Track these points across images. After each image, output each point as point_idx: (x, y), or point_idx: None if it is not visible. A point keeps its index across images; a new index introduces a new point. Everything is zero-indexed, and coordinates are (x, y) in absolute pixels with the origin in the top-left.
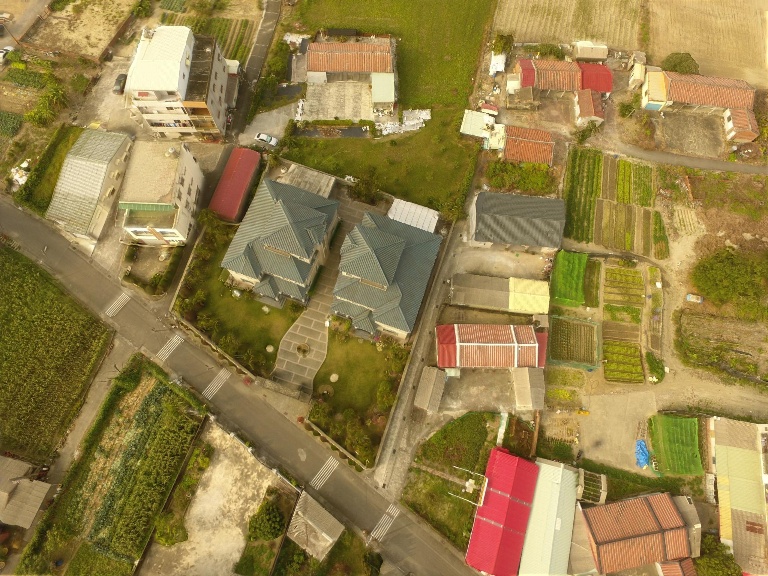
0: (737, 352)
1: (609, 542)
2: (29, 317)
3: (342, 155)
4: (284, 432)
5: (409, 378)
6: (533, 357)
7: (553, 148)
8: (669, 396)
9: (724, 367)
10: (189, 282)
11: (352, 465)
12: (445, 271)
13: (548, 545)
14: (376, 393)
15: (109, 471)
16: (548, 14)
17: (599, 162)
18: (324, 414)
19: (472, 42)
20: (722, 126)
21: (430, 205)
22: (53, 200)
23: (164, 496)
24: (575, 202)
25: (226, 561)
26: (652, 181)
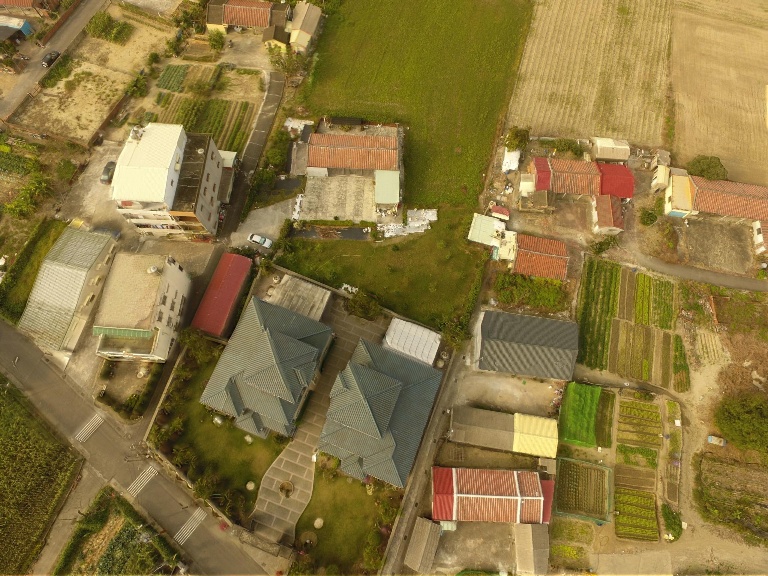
0: (762, 506)
1: None
2: None
3: (340, 260)
4: None
5: (400, 526)
6: (537, 512)
7: None
8: (686, 558)
9: (748, 525)
10: None
11: None
12: (445, 399)
13: None
14: (363, 546)
15: None
16: (567, 103)
17: (616, 275)
18: None
19: (485, 133)
20: (751, 237)
21: (432, 322)
22: (27, 309)
23: None
24: (589, 322)
25: None
26: (673, 299)
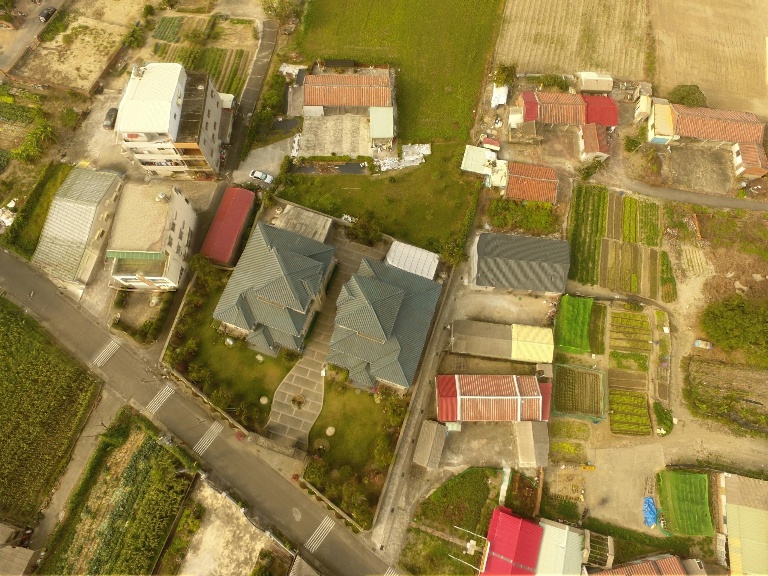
0: (748, 401)
1: None
2: (14, 368)
3: (339, 193)
4: (278, 490)
5: (408, 431)
6: (537, 410)
7: (557, 185)
8: (678, 449)
9: (734, 418)
10: (180, 330)
11: (349, 526)
12: (445, 316)
13: None
14: (374, 448)
15: (96, 533)
16: (551, 42)
17: (604, 199)
18: (319, 474)
19: (473, 72)
20: (731, 160)
21: (430, 246)
22: (40, 244)
23: (152, 561)
24: (580, 242)
25: None
26: (659, 219)
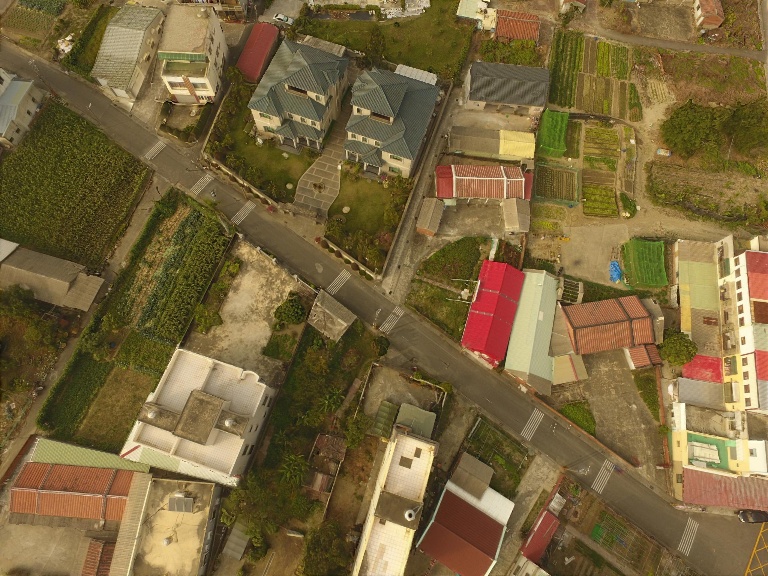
0: (701, 196)
1: (584, 327)
2: (79, 156)
3: (351, 34)
4: (303, 250)
5: (412, 211)
6: (520, 190)
7: None
8: (640, 228)
9: (689, 206)
10: (218, 131)
11: (363, 275)
12: (443, 128)
13: (532, 331)
14: (383, 219)
15: (152, 277)
16: None
17: (581, 43)
18: (338, 228)
19: None
20: (692, 15)
21: None
22: (97, 61)
23: (201, 295)
24: (559, 75)
25: (255, 346)
26: (628, 59)
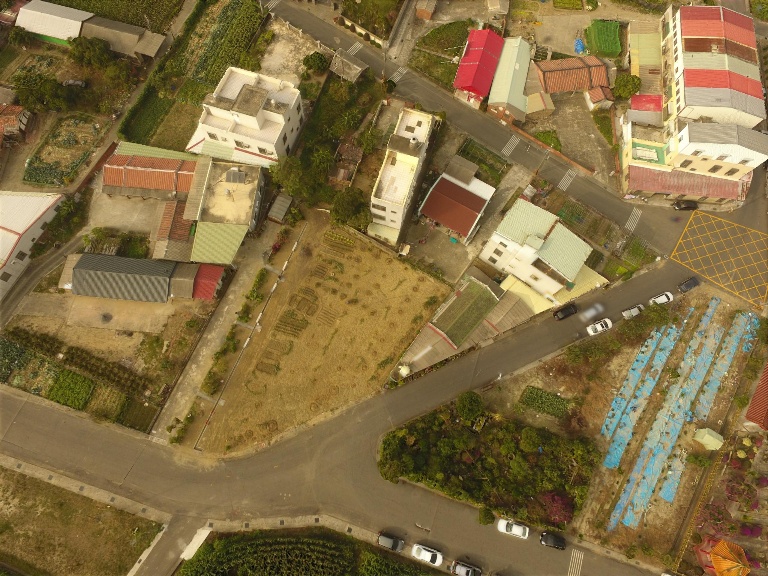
0: None
1: (552, 71)
2: None
3: None
4: (324, 28)
5: (412, 3)
6: None
7: None
8: (600, 18)
9: (641, 2)
10: None
11: (373, 44)
12: None
13: (510, 76)
14: None
15: (202, 44)
16: None
17: None
18: None
19: None
20: None
21: None
22: None
23: None
24: None
25: None
26: None
